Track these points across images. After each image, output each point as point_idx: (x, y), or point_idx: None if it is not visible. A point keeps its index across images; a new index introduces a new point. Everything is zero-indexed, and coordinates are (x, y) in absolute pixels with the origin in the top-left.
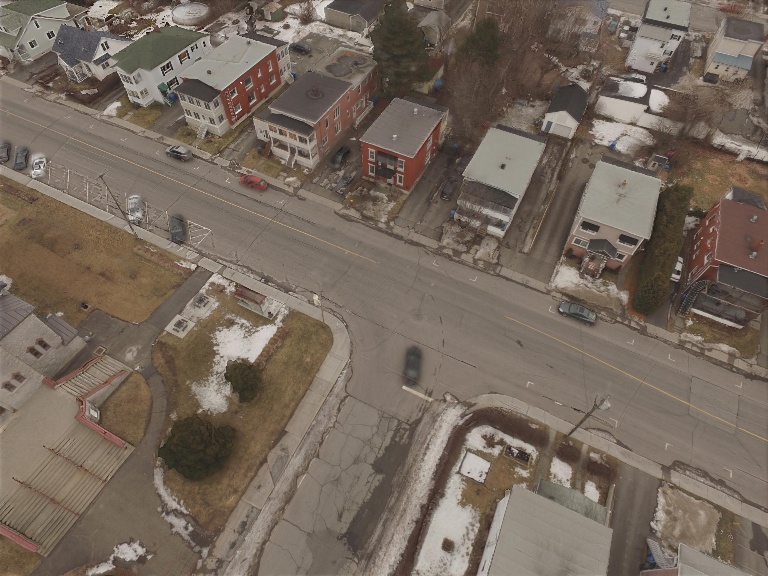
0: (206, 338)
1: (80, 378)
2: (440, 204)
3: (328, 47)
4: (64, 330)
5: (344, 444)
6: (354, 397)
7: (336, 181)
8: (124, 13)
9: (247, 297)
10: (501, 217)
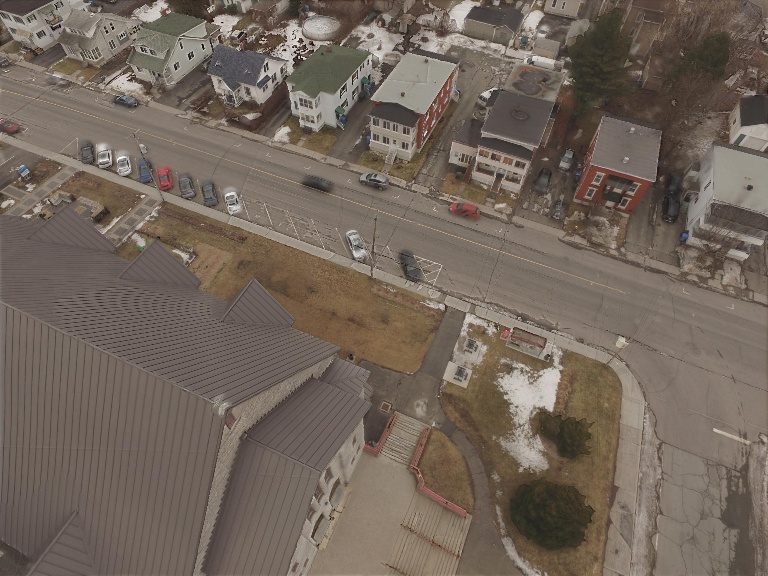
0: (491, 386)
1: (390, 441)
2: (664, 227)
3: (477, 60)
4: (364, 389)
5: (682, 497)
6: (669, 444)
7: (547, 206)
8: (249, 29)
9: (528, 340)
10: (754, 241)
